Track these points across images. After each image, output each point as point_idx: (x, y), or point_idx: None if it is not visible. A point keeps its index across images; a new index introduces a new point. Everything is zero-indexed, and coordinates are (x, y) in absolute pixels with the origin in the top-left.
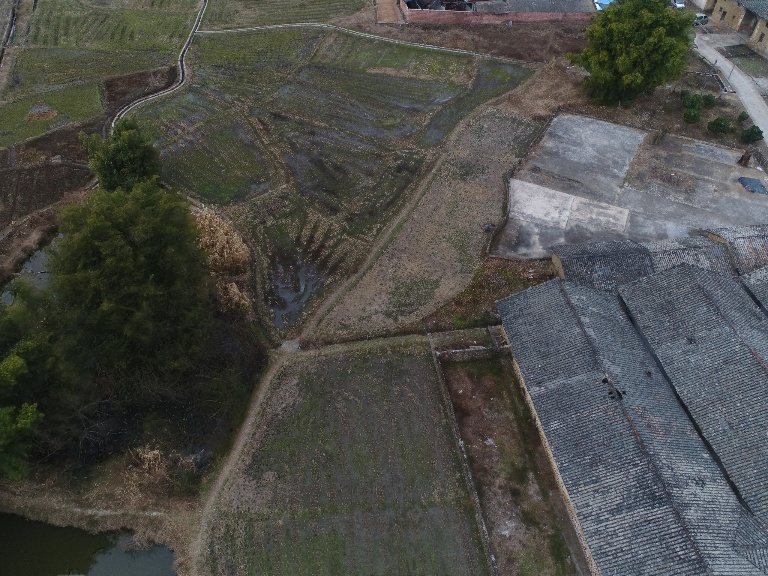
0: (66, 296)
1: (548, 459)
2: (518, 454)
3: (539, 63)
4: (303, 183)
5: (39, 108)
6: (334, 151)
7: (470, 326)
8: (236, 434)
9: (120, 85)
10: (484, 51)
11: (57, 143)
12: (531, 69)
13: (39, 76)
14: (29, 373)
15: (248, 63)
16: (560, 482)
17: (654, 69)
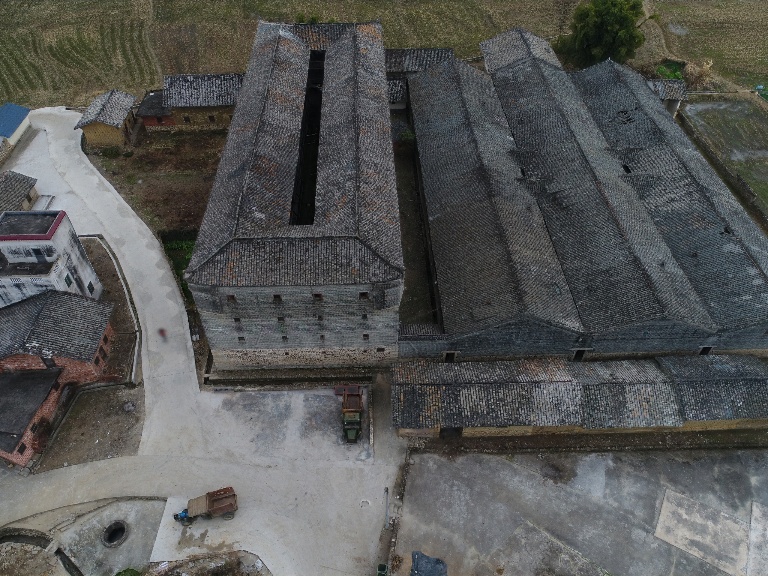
0: None
1: None
2: None
3: None
4: None
5: None
6: None
7: None
8: None
9: None
10: None
11: None
12: None
13: None
14: None
15: None
16: None
17: None
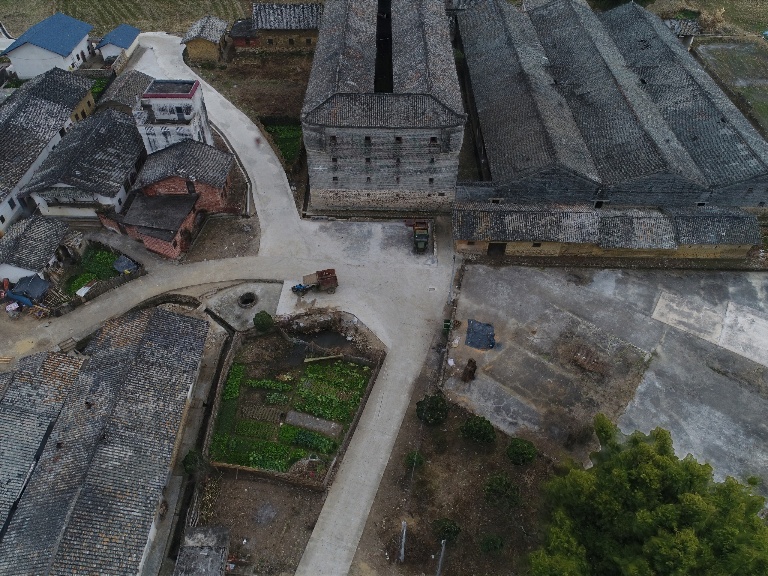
0: None
1: None
2: None
3: None
4: None
5: None
6: None
7: None
8: None
9: None
10: None
11: None
12: None
13: None
14: None
15: None
16: None
17: None
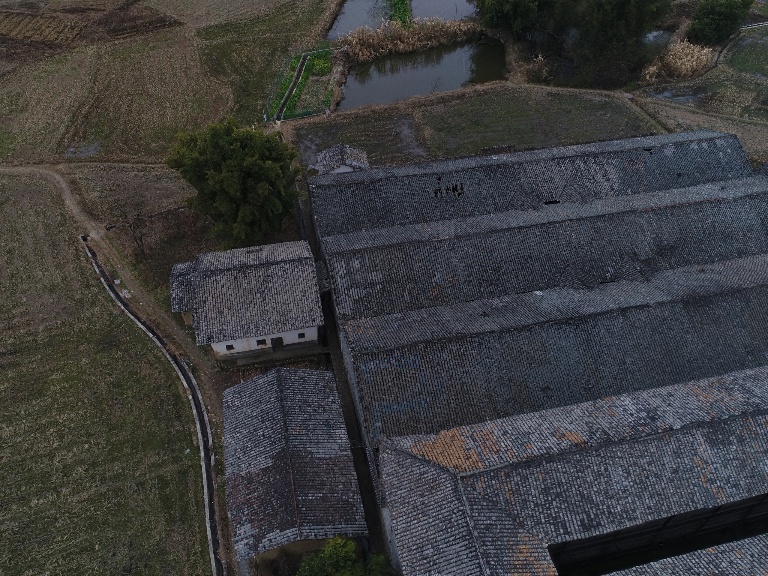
0: None
1: None
2: None
3: None
4: None
5: (760, 1)
6: None
7: None
8: (566, 87)
9: None
10: None
11: None
12: None
13: None
14: None
15: None
16: None
17: None
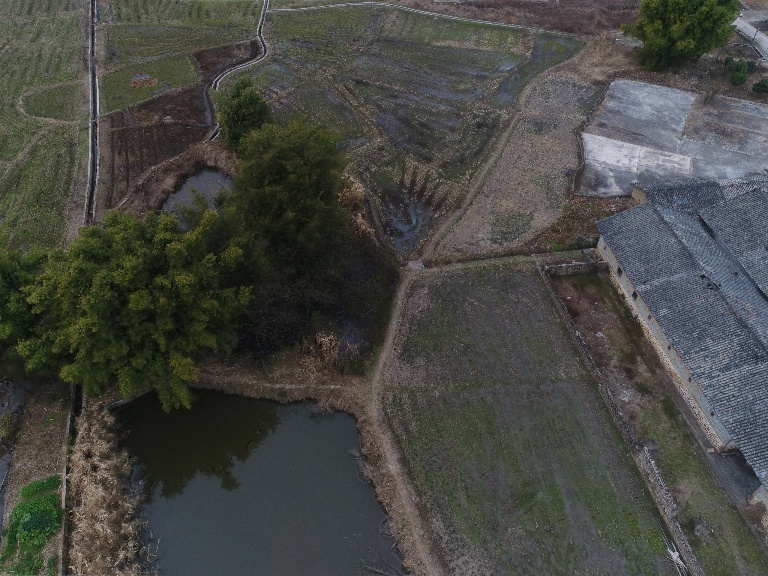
0: (253, 208)
1: (652, 346)
2: (625, 343)
3: (589, 36)
4: (395, 138)
5: (140, 76)
6: (417, 111)
7: (566, 249)
8: (385, 330)
9: (209, 57)
10: (537, 26)
11: (166, 106)
12: (583, 41)
13: (132, 49)
14: (239, 265)
15: (321, 37)
16: (666, 361)
17: (704, 36)
